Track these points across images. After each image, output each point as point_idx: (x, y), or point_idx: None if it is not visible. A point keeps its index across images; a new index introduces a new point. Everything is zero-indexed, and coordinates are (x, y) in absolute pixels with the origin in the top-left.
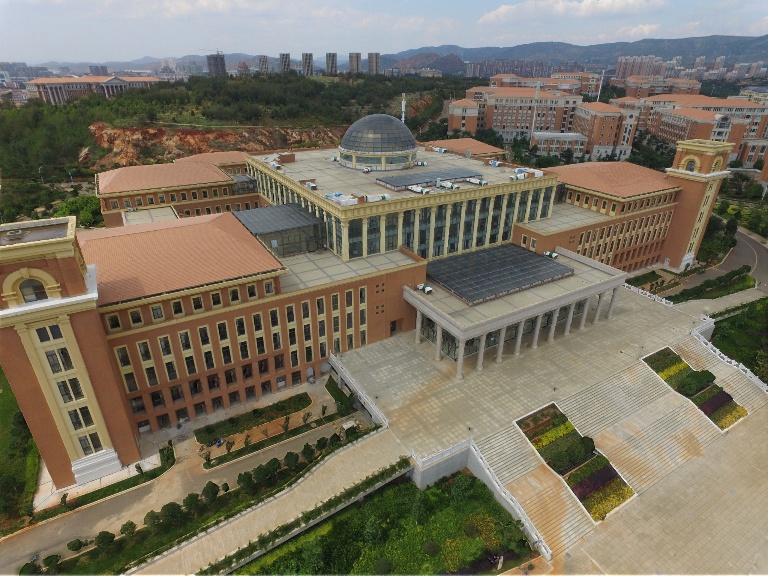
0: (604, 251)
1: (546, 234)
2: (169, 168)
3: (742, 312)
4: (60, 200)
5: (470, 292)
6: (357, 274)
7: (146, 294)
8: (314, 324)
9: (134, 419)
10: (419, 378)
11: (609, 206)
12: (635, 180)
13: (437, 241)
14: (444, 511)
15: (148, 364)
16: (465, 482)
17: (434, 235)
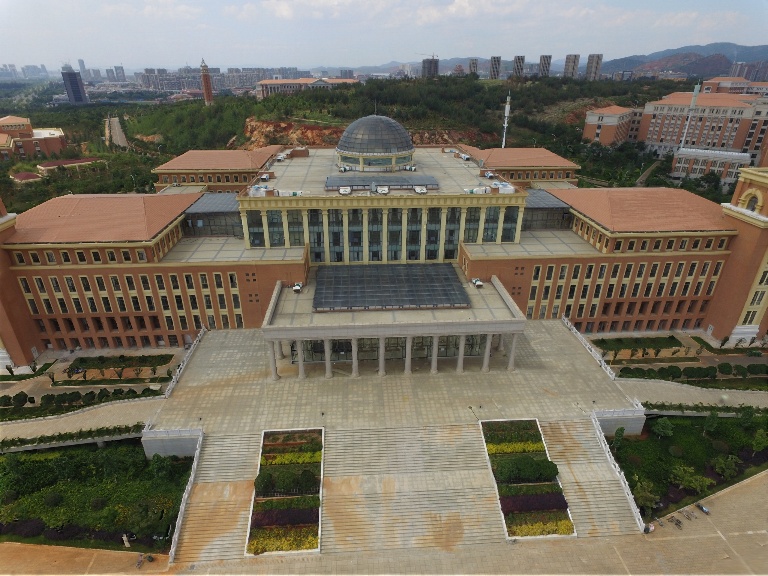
0: (584, 295)
1: (473, 258)
2: (219, 154)
3: (711, 413)
4: None
5: (324, 299)
6: (237, 260)
7: (38, 241)
8: (184, 296)
9: (39, 335)
10: (243, 368)
11: (602, 240)
12: (664, 213)
13: (355, 246)
14: (143, 482)
15: (44, 296)
16: (159, 462)
17: (350, 239)
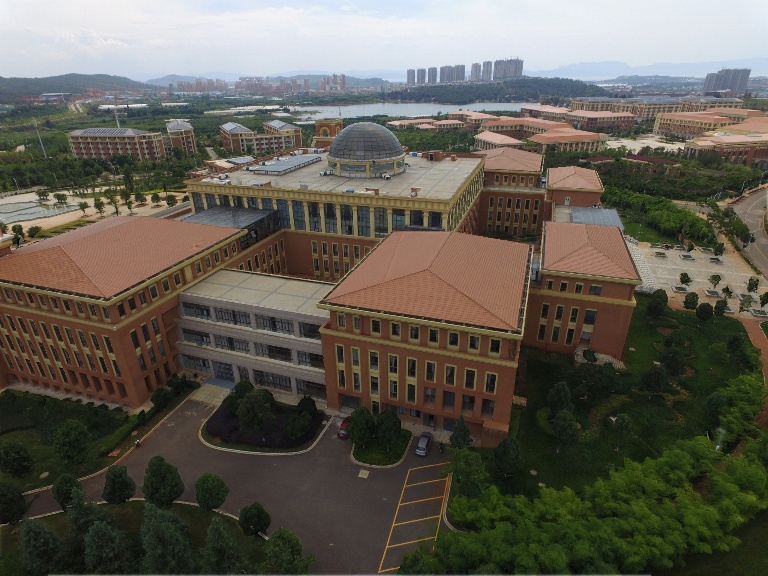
0: None
1: None
2: None
3: None
4: (670, 199)
5: None
6: None
7: None
8: None
9: None
10: None
11: None
12: (78, 232)
13: None
14: None
15: None
16: None
17: None
